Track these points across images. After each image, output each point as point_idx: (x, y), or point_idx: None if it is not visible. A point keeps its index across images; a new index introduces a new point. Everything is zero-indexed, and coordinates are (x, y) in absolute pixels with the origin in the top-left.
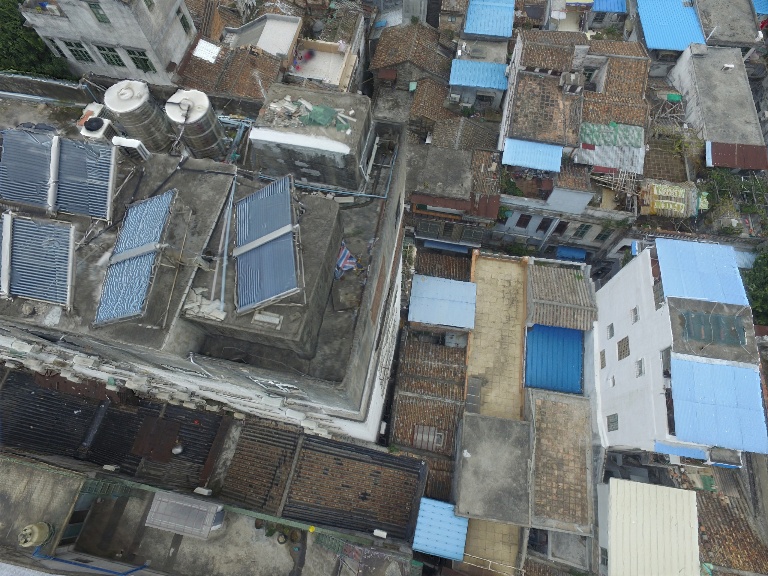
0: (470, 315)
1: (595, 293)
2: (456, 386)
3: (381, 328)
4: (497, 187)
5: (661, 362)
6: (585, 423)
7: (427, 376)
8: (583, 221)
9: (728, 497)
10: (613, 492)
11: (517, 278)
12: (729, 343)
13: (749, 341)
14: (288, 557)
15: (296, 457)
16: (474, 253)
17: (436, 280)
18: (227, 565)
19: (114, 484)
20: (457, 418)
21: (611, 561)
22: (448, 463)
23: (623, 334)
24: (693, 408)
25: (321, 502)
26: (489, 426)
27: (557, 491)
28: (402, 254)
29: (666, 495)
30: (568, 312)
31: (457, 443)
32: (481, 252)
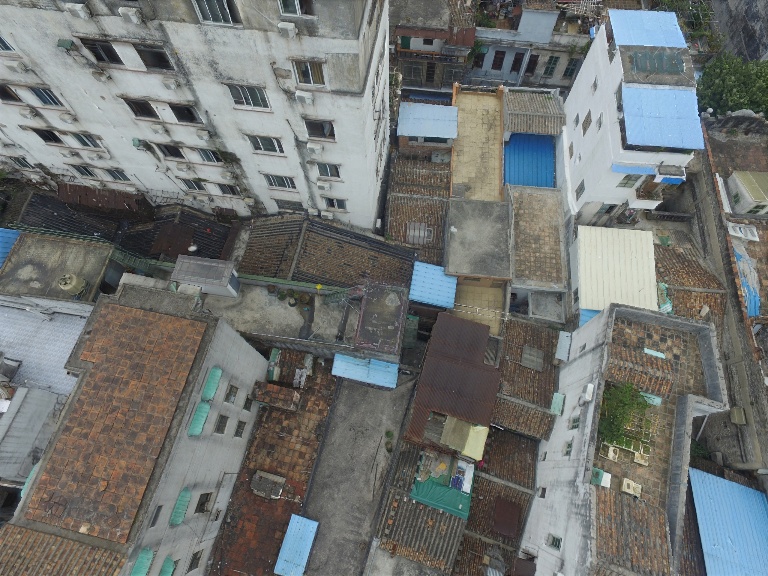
0: (453, 129)
1: (563, 105)
2: (442, 190)
3: (373, 10)
4: (472, 20)
5: (615, 101)
6: (558, 208)
7: (416, 183)
8: (551, 49)
9: (682, 248)
10: (581, 236)
11: (494, 108)
12: (670, 72)
13: (687, 70)
14: (299, 316)
15: (302, 237)
16: (454, 85)
17: (421, 105)
18: (244, 325)
19: (139, 259)
20: (444, 214)
21: (581, 287)
22: (438, 251)
23: (586, 111)
24: (641, 121)
25: (326, 275)
26: (473, 208)
27: (535, 259)
28: (389, 81)
29: (627, 235)
30: (540, 120)
31: (445, 233)
32: (461, 85)
